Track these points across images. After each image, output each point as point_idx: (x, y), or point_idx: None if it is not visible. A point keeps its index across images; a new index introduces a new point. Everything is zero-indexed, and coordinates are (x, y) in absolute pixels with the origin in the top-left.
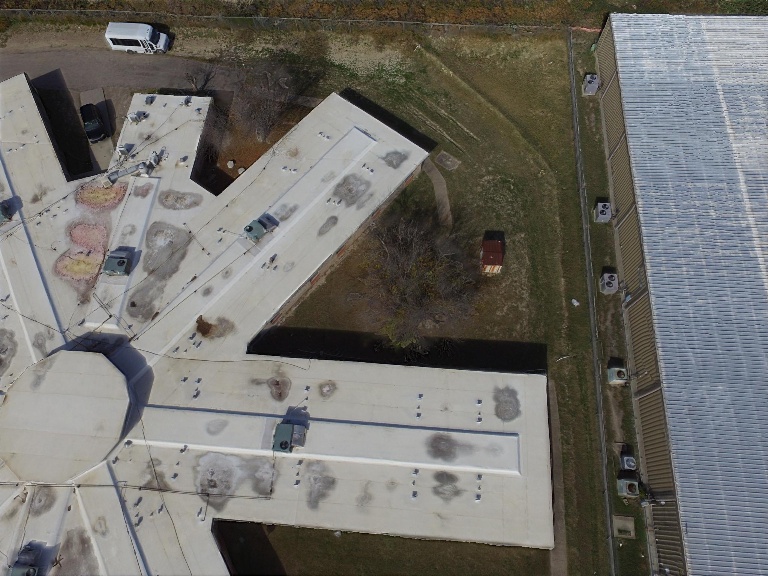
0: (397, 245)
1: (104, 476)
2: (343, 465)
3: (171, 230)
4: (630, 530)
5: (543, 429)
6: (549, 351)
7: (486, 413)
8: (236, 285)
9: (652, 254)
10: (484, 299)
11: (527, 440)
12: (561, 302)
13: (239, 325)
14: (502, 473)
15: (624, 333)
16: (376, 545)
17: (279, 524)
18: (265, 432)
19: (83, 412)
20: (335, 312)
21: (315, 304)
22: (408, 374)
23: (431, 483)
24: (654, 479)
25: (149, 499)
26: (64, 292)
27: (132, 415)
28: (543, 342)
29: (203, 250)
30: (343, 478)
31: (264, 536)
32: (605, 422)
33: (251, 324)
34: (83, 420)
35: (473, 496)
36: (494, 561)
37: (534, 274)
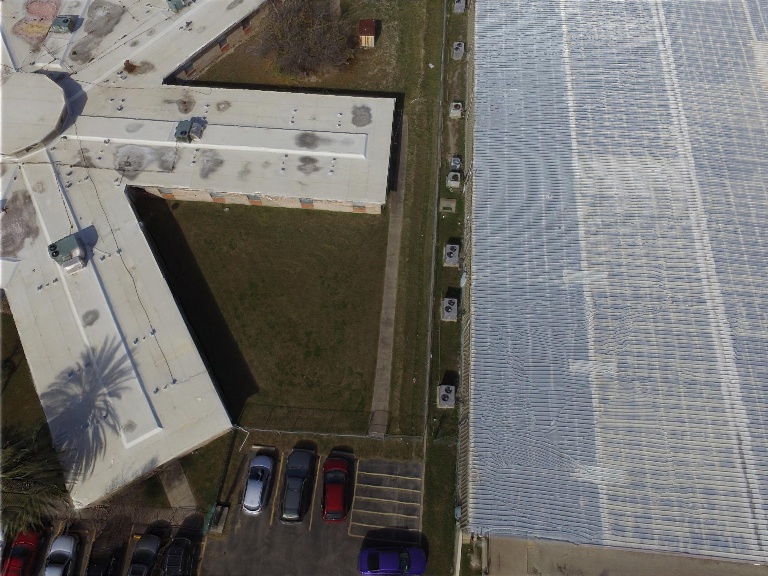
0: (283, 3)
1: (43, 157)
2: (230, 152)
3: (109, 6)
4: (452, 207)
5: (387, 131)
6: (406, 97)
7: (344, 121)
8: (158, 41)
9: (481, 10)
10: (359, 64)
11: (374, 138)
12: (420, 65)
13: (158, 66)
14: (351, 156)
15: (466, 84)
16: (255, 217)
17: (177, 188)
18: (171, 131)
19: (28, 110)
20: (239, 71)
21: (224, 66)
22: (287, 97)
23: (296, 163)
24: (468, 164)
25: (78, 173)
26: (19, 45)
27: (68, 120)
28: (402, 92)
29: (133, 18)
30: (229, 160)
31: (169, 212)
32: (443, 141)
33: (167, 66)
34: (28, 115)
35: (327, 171)
36: (345, 227)
37: (402, 48)
